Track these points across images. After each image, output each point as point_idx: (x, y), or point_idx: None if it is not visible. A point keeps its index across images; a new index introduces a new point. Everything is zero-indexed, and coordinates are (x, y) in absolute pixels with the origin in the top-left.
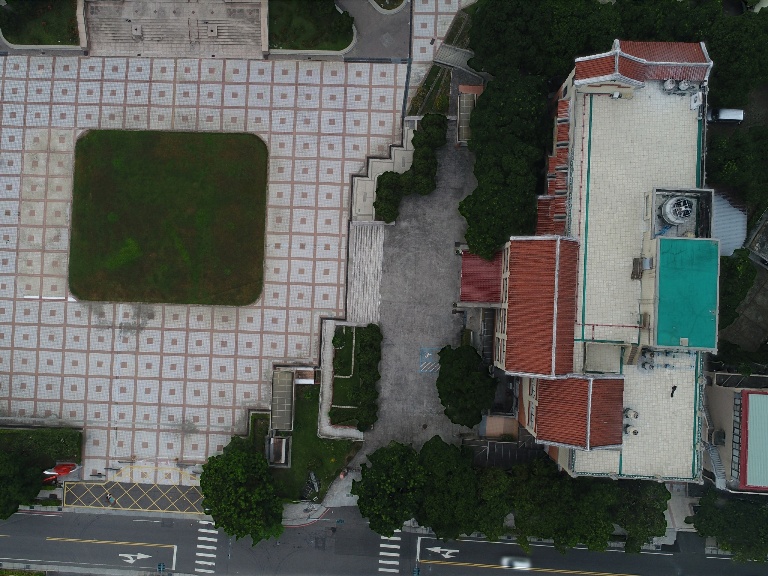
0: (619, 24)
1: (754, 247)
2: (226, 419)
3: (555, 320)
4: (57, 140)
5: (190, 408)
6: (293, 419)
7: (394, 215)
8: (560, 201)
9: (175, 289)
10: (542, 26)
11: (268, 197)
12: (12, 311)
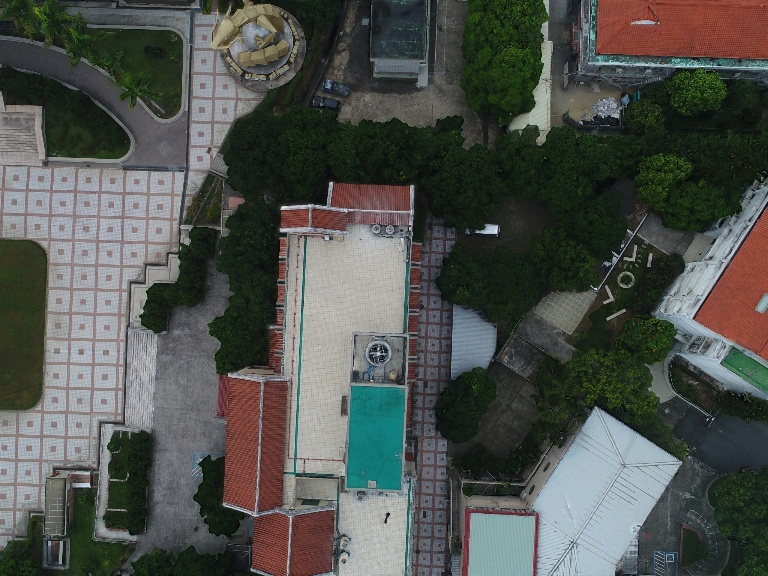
0: (354, 155)
1: (503, 359)
2: (7, 521)
3: (258, 460)
4: None
5: None
6: (67, 524)
7: (160, 327)
8: (279, 337)
9: None
10: (279, 158)
11: (47, 303)
12: None
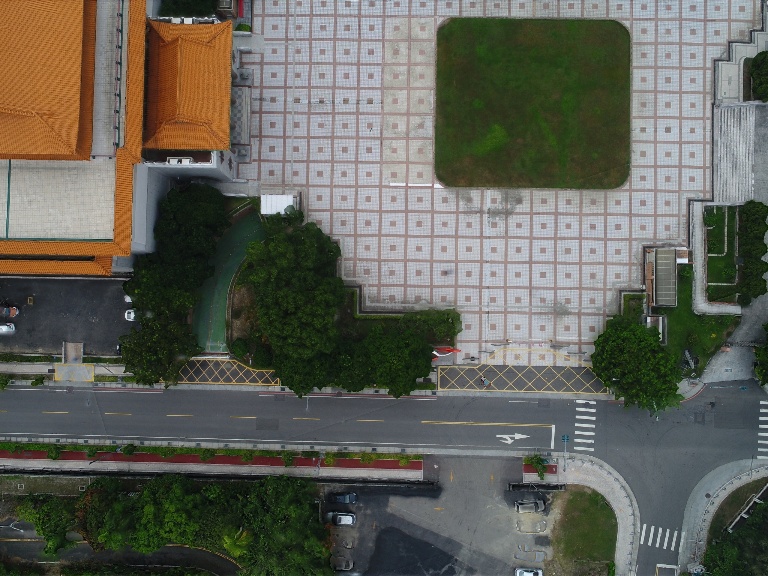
0: None
1: None
2: (597, 300)
3: None
4: (418, 28)
5: (561, 290)
6: None
7: None
8: None
9: (543, 174)
10: None
11: (632, 82)
12: (378, 198)
